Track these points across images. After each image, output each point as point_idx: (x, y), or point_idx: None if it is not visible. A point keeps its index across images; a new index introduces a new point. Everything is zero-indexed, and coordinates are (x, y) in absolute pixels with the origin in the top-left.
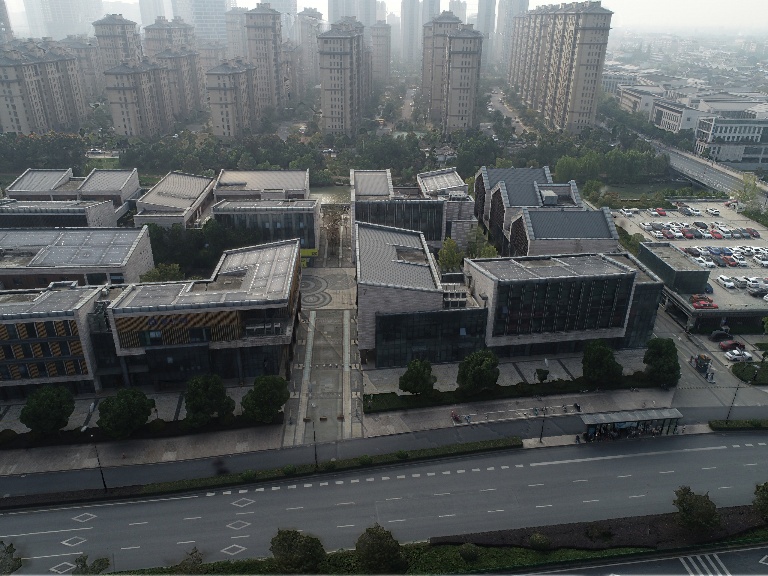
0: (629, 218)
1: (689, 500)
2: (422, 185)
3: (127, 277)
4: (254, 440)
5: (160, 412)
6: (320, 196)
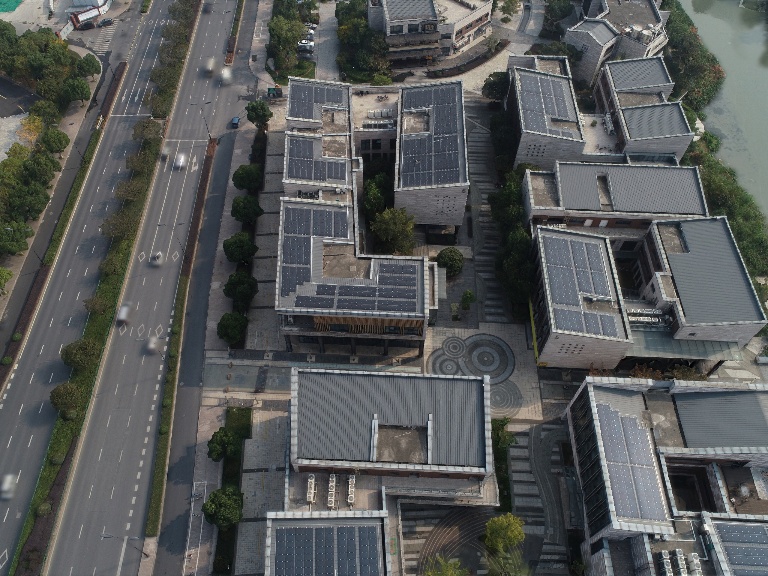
0: None
1: None
2: (761, 515)
3: (396, 199)
4: None
5: (266, 271)
6: (727, 357)
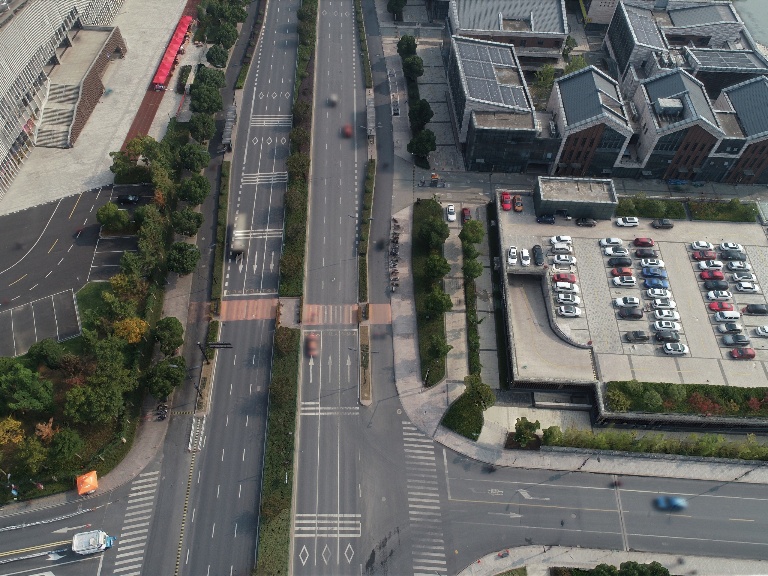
0: (767, 247)
1: (304, 105)
2: None
3: None
4: (384, 14)
5: None
6: None
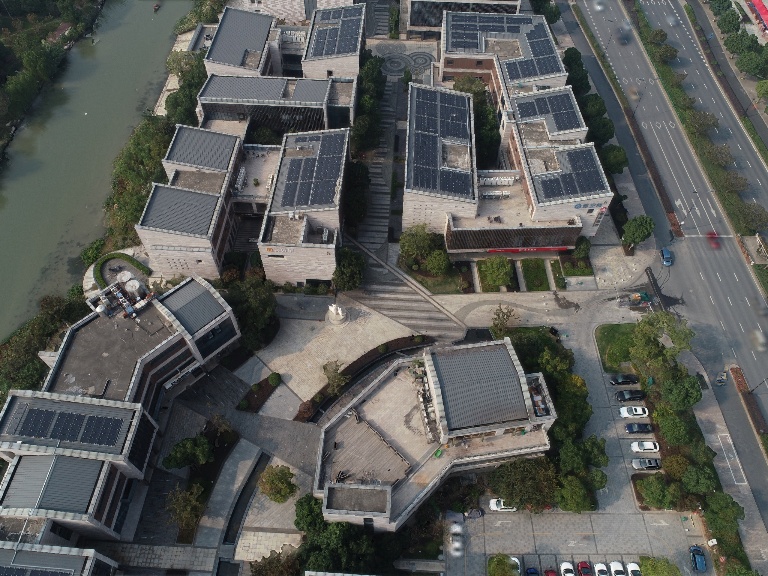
0: None
1: None
2: None
3: None
4: None
5: None
6: None
